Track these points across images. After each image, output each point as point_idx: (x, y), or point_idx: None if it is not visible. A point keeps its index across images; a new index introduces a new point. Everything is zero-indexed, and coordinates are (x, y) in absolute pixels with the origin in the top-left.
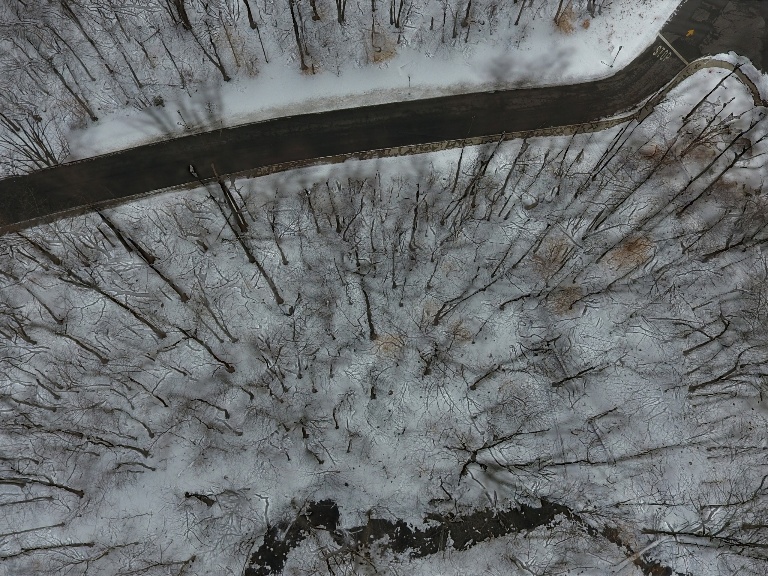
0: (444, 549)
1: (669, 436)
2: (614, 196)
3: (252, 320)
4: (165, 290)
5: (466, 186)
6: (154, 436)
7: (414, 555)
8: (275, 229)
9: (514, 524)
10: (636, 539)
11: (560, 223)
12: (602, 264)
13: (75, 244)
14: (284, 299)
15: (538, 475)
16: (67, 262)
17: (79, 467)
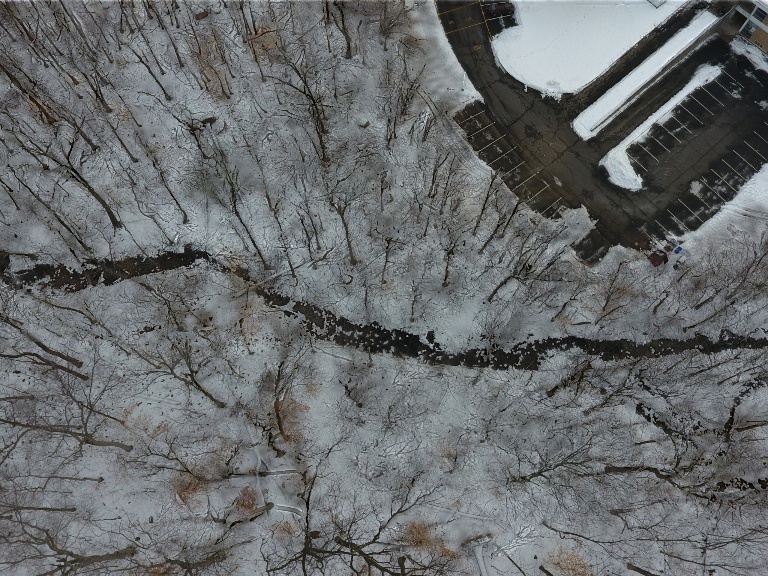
0: (95, 285)
1: None
2: (275, 7)
3: None
4: None
5: (146, 1)
6: None
7: (69, 290)
8: None
9: (159, 266)
10: (262, 275)
11: (223, 29)
12: (259, 62)
13: None
14: None
15: (183, 227)
16: None
17: None
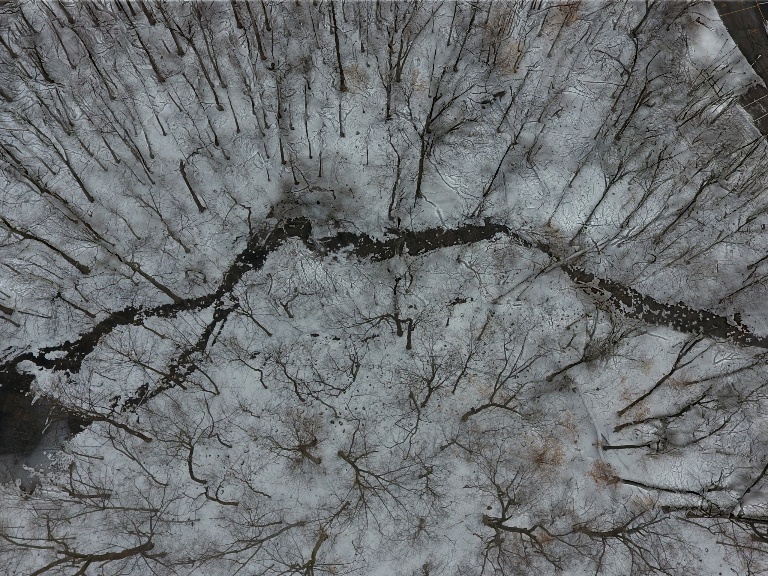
0: (400, 255)
1: (596, 173)
2: None
3: (239, 67)
4: (164, 37)
5: None
6: (154, 157)
7: (375, 259)
8: (260, 1)
9: (461, 239)
10: (565, 252)
11: None
12: None
13: (87, 2)
14: (267, 57)
15: None
16: (80, 20)
17: (91, 163)
